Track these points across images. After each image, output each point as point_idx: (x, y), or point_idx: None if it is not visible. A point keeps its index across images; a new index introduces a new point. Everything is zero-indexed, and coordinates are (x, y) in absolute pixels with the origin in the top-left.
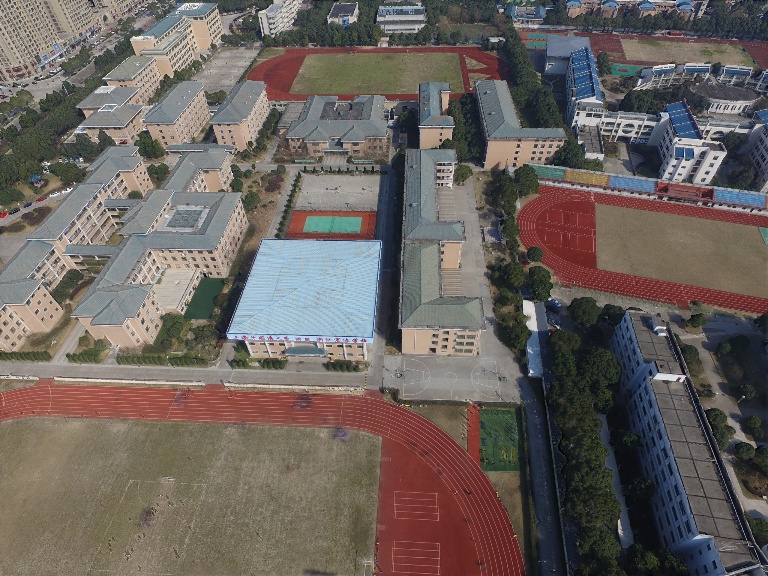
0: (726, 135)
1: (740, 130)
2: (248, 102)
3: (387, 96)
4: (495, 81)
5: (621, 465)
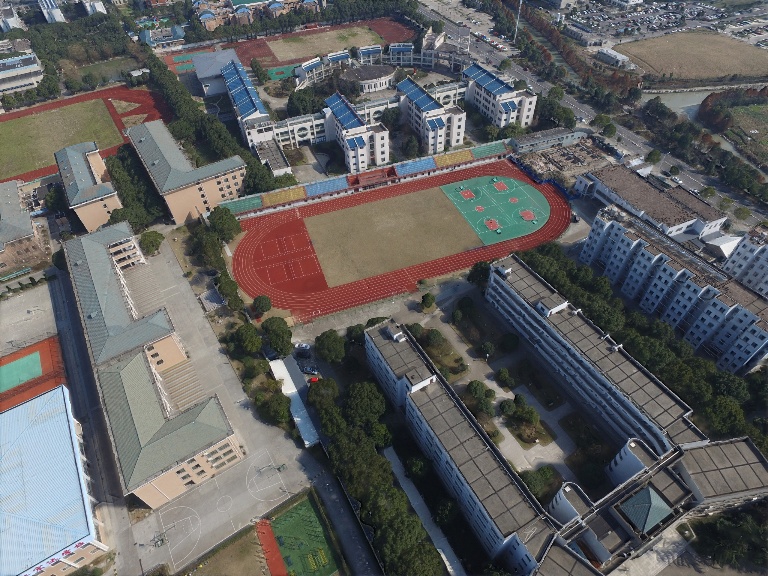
0: (383, 113)
1: (392, 105)
2: None
3: (24, 176)
4: (146, 124)
5: (424, 493)
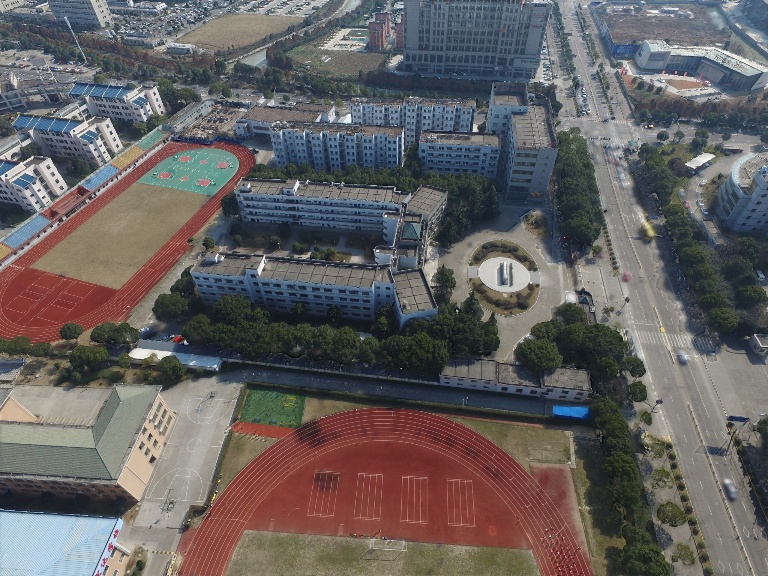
0: (22, 153)
1: (24, 143)
2: None
3: None
4: None
5: (314, 325)
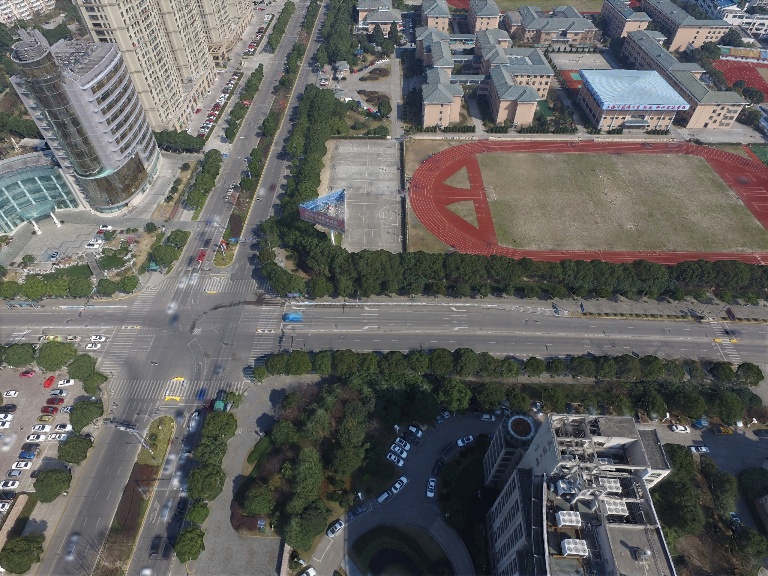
0: None
1: None
2: None
3: None
4: None
5: None
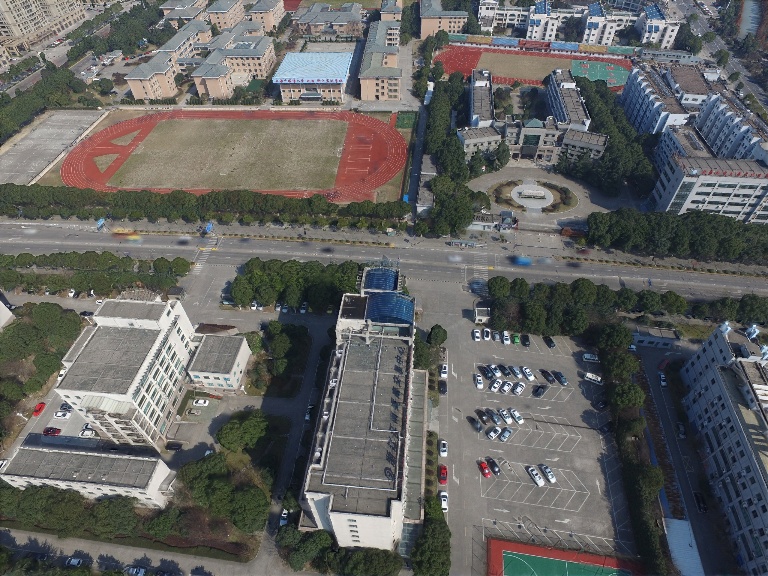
0: (569, 18)
1: (577, 15)
2: (273, 1)
3: None
4: None
5: None
